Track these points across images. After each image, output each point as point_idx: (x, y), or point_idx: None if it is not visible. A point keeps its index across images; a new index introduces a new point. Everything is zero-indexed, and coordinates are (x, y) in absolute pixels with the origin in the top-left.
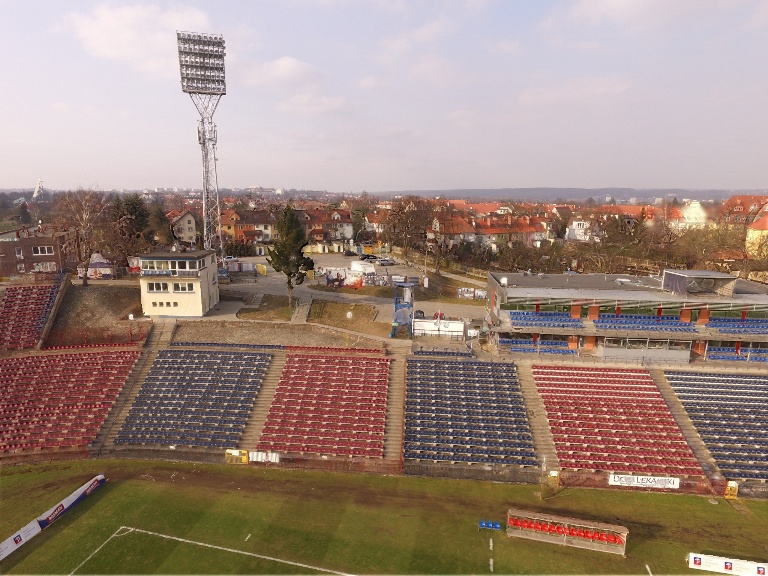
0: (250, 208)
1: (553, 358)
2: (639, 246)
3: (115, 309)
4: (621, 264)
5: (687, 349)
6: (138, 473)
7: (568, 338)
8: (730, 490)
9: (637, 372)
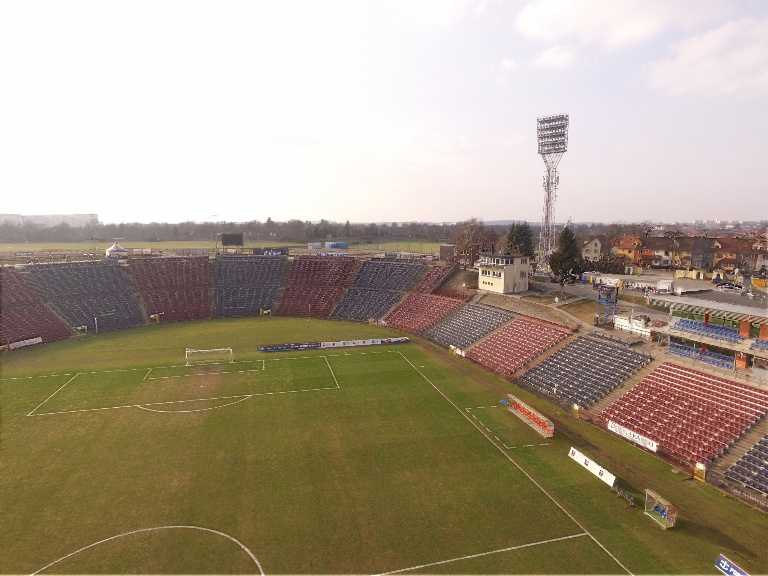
0: (641, 234)
1: (698, 364)
2: None
3: (468, 283)
4: None
5: None
6: None
7: (737, 355)
8: (699, 472)
9: (766, 394)
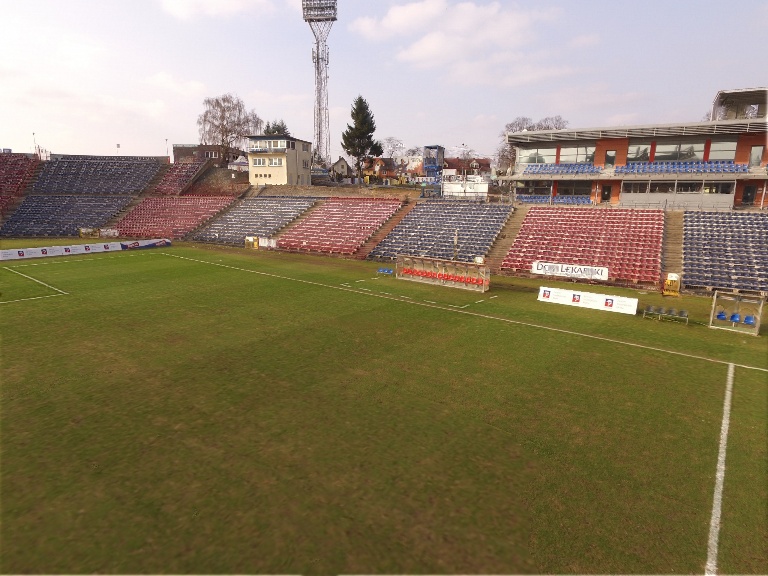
0: (388, 150)
1: None
2: None
3: (233, 180)
4: None
5: (731, 192)
6: None
7: (591, 192)
8: (670, 285)
9: (649, 212)
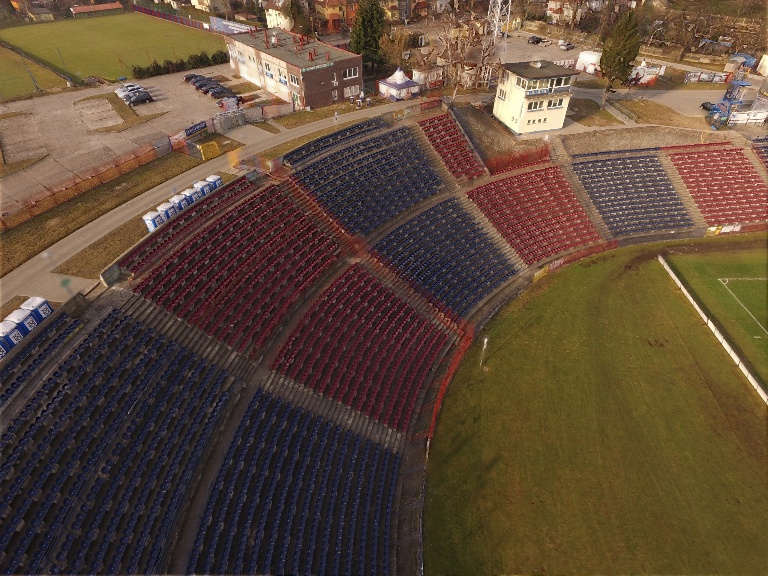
0: None
1: None
2: (738, 3)
3: (497, 131)
4: (723, 25)
5: None
6: (665, 251)
7: None
8: None
9: None
